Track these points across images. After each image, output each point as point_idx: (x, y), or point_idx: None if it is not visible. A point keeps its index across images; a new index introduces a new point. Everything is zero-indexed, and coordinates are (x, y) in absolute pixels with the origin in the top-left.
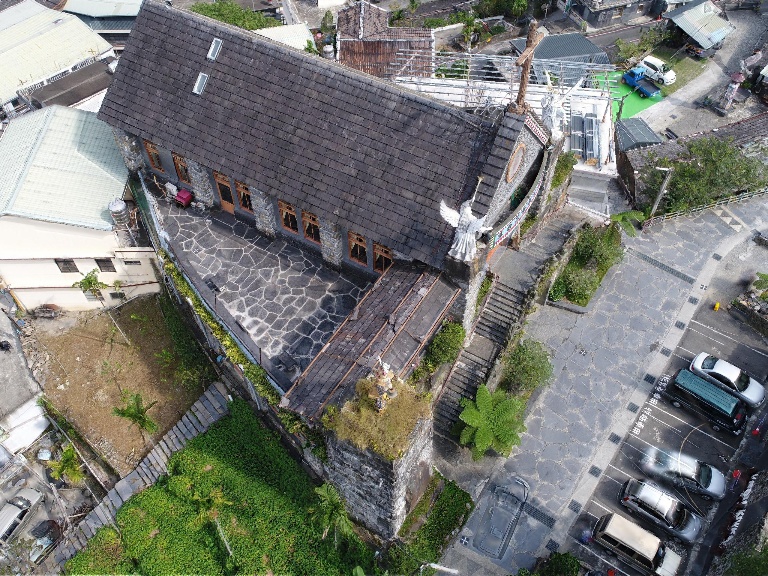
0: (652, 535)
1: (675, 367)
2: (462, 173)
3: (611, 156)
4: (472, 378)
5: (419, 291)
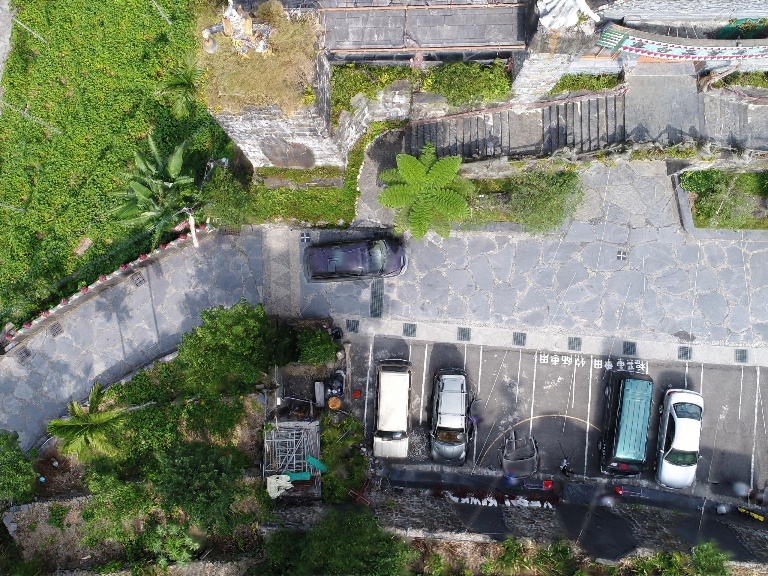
0: (406, 420)
1: (666, 371)
2: None
3: None
4: (480, 142)
5: None
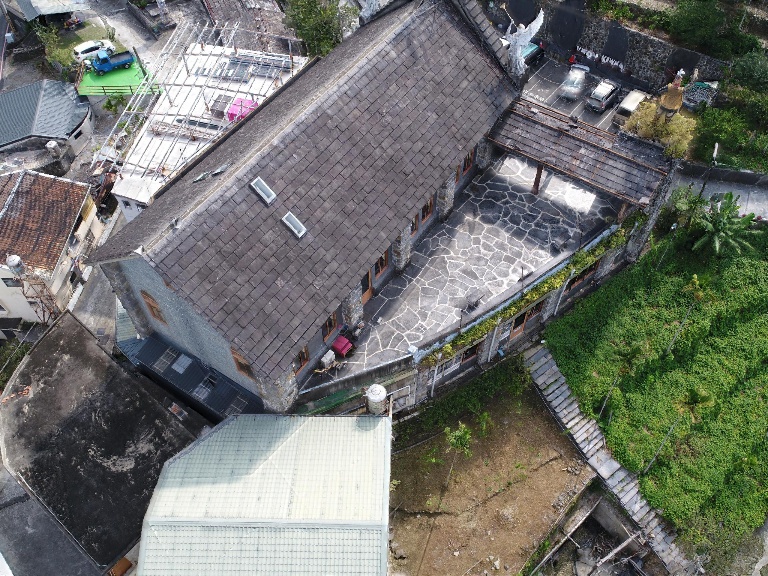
0: (631, 92)
1: None
2: (462, 38)
3: (284, 56)
4: None
5: (535, 112)
